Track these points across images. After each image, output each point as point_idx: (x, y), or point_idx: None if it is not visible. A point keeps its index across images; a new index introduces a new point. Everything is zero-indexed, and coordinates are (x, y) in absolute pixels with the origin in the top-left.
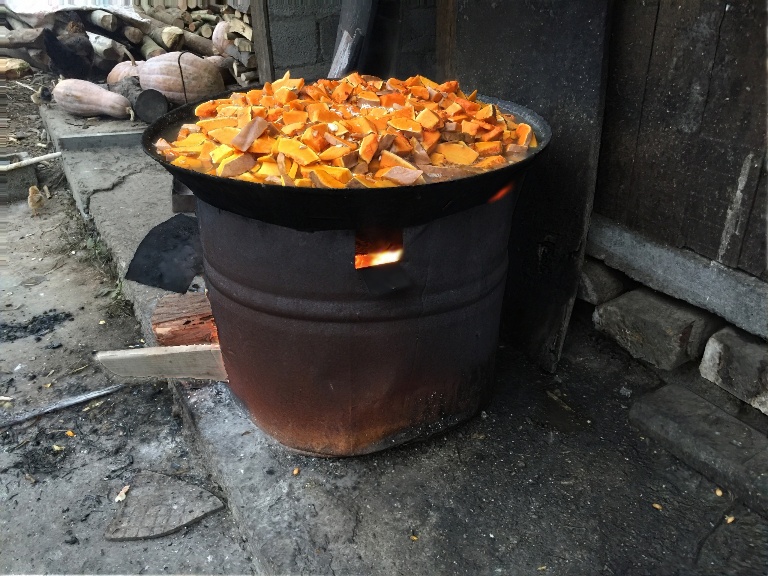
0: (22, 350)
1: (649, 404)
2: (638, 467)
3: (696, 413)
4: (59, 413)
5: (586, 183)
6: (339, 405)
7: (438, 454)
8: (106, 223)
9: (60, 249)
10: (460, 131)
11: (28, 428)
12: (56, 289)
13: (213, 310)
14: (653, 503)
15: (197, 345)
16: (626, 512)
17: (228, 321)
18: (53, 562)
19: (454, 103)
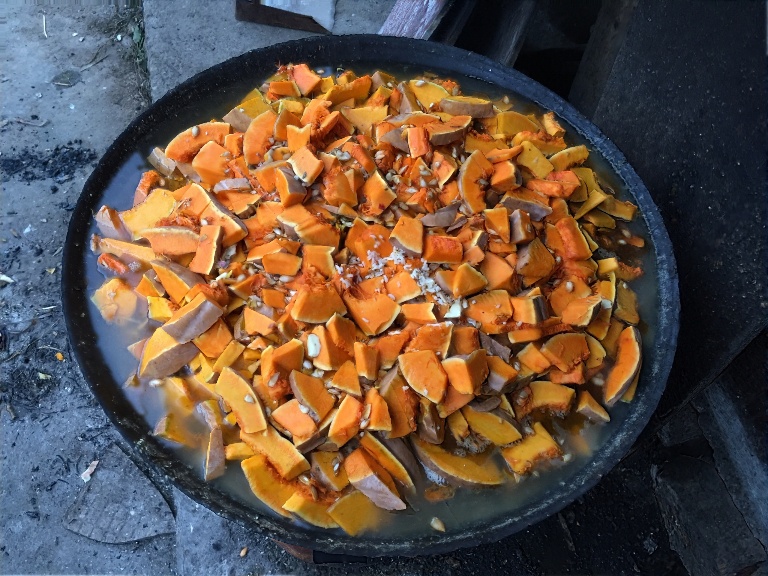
0: (36, 202)
1: None
2: None
3: None
4: (55, 320)
5: (713, 361)
6: None
7: (400, 571)
8: (152, 21)
9: (106, 25)
10: (511, 382)
11: (21, 333)
12: (88, 102)
13: None
14: None
15: None
16: None
17: None
18: (12, 535)
19: (530, 302)
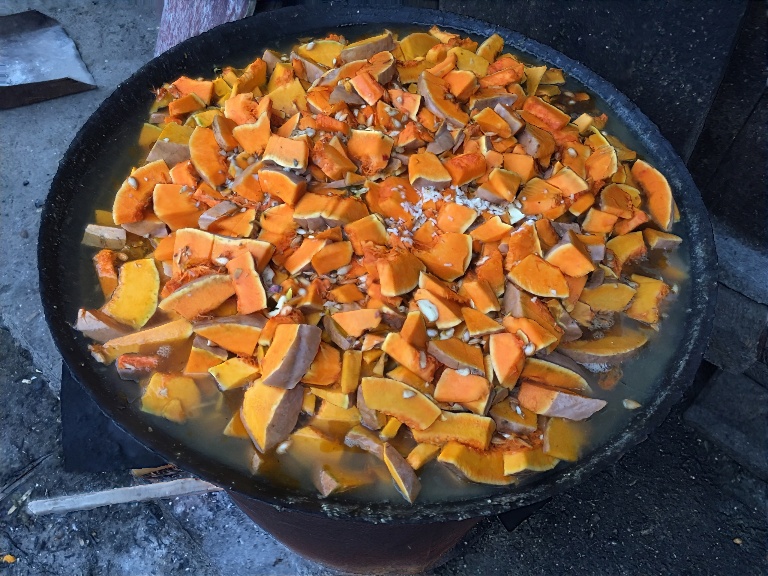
0: None
1: (710, 409)
2: (707, 487)
3: (758, 413)
4: None
5: None
6: (416, 554)
7: None
8: None
9: None
10: None
11: None
12: None
13: None
14: (734, 539)
15: (183, 482)
16: (712, 558)
17: (250, 500)
18: None
19: (571, 173)
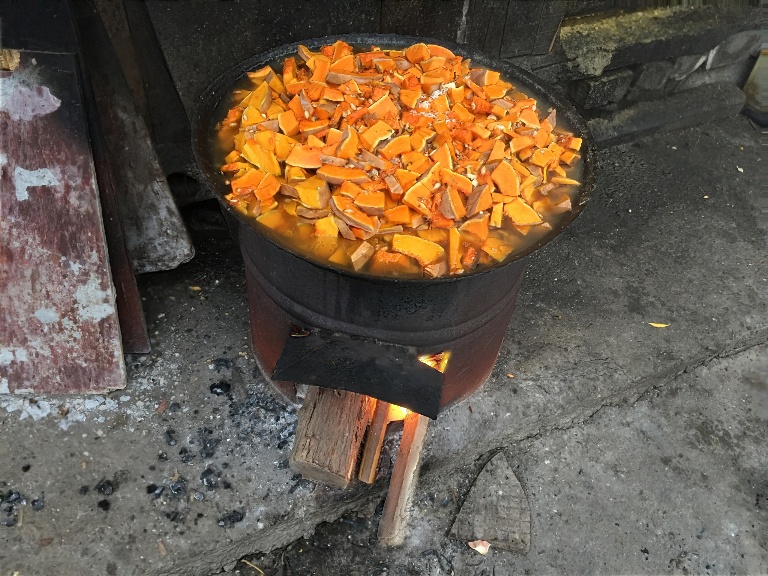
0: None
1: None
2: None
3: None
4: None
5: None
6: None
7: None
8: None
9: None
10: None
11: None
12: None
13: (451, 360)
14: None
15: None
16: None
17: None
18: None
19: (435, 58)
